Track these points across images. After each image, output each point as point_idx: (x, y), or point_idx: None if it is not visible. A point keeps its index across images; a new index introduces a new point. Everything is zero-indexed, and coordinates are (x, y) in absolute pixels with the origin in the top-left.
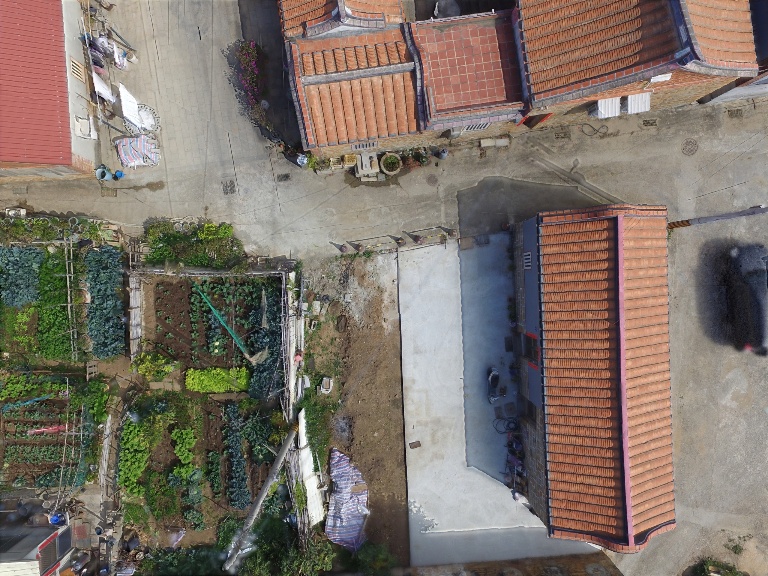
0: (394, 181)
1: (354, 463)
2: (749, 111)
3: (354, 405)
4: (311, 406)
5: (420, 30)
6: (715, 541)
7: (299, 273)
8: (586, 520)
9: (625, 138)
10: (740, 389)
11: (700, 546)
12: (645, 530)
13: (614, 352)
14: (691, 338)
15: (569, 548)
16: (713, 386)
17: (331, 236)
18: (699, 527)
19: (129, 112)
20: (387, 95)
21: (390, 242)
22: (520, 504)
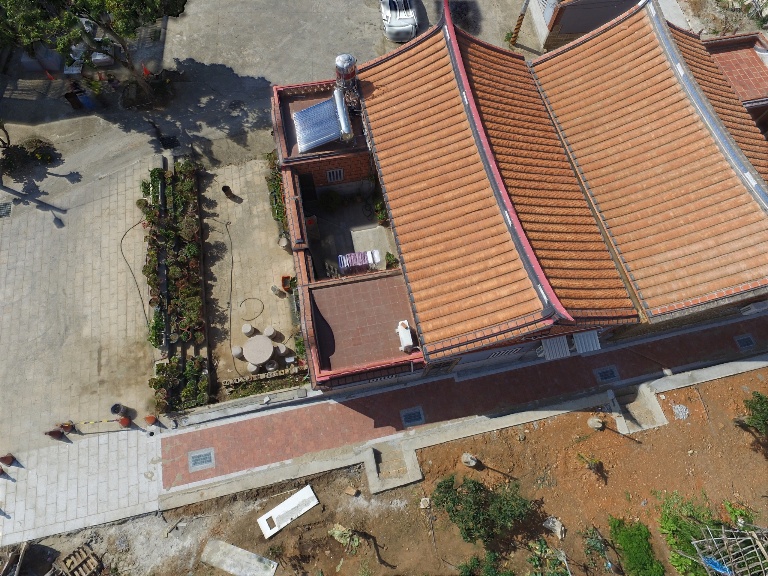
0: None
1: None
2: None
3: None
4: None
5: None
6: None
7: (759, 20)
8: None
9: None
10: None
11: None
12: None
13: None
14: None
15: None
16: None
17: None
18: None
19: None
20: None
21: None
22: None
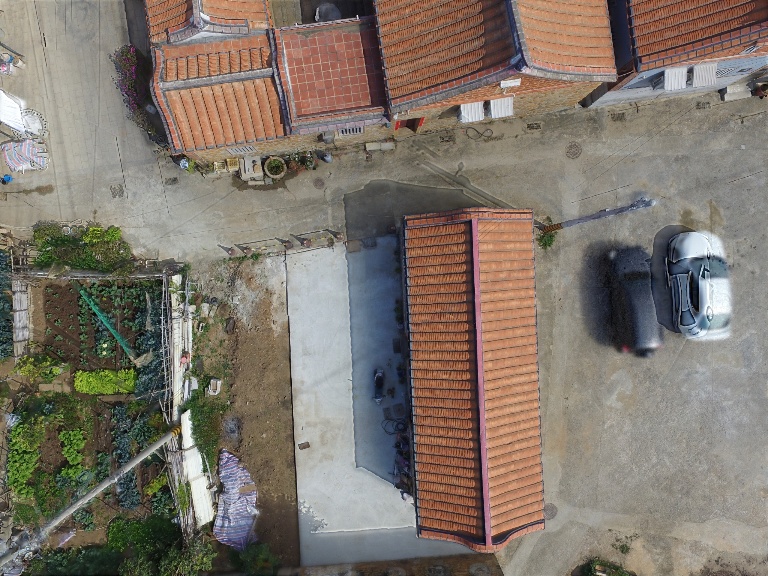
0: (281, 184)
1: (243, 464)
2: (632, 115)
3: (242, 406)
4: (198, 407)
5: (284, 36)
6: (602, 541)
7: (187, 276)
8: (450, 520)
9: (509, 141)
10: (625, 390)
11: (588, 546)
12: (508, 530)
13: (473, 354)
14: (576, 339)
15: (458, 548)
16: (598, 387)
17: (219, 239)
18: (586, 527)
19: (8, 117)
20: (250, 100)
21: (274, 245)
22: (409, 504)
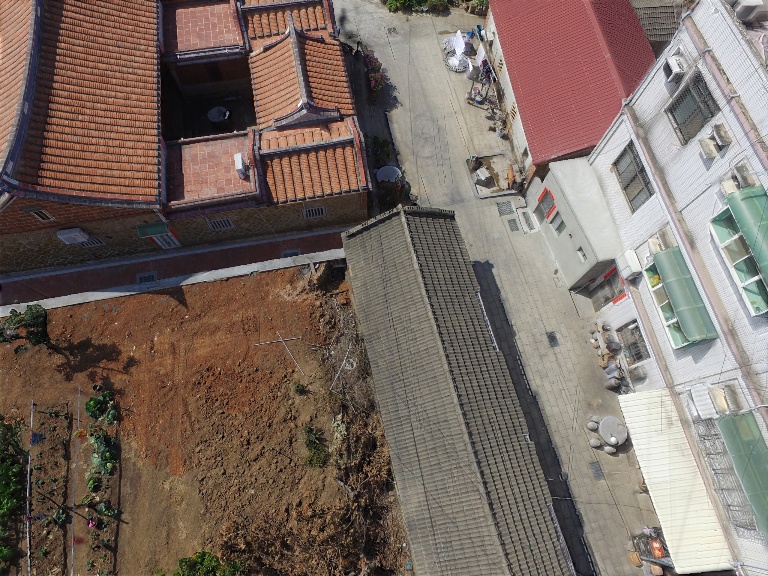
0: None
1: None
2: None
3: None
4: None
5: None
6: None
7: None
8: None
9: None
10: None
11: None
12: None
13: None
14: None
15: None
16: None
17: None
18: None
19: None
20: None
21: None
22: None
